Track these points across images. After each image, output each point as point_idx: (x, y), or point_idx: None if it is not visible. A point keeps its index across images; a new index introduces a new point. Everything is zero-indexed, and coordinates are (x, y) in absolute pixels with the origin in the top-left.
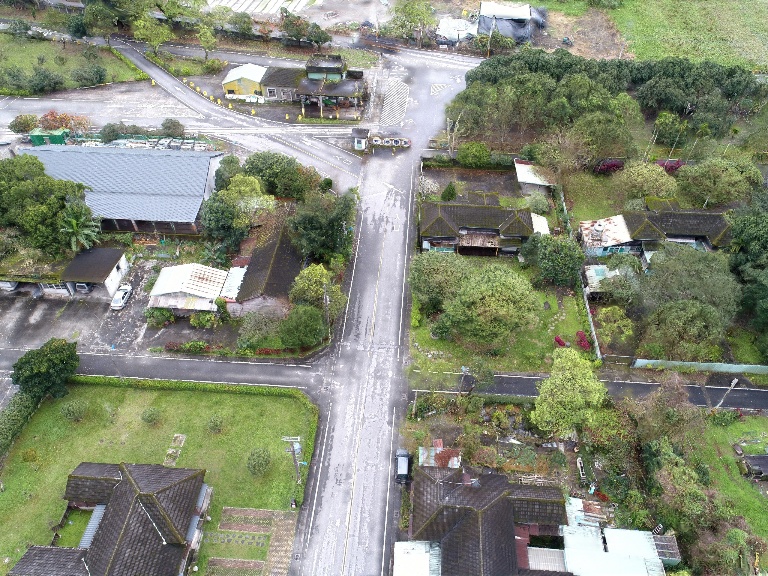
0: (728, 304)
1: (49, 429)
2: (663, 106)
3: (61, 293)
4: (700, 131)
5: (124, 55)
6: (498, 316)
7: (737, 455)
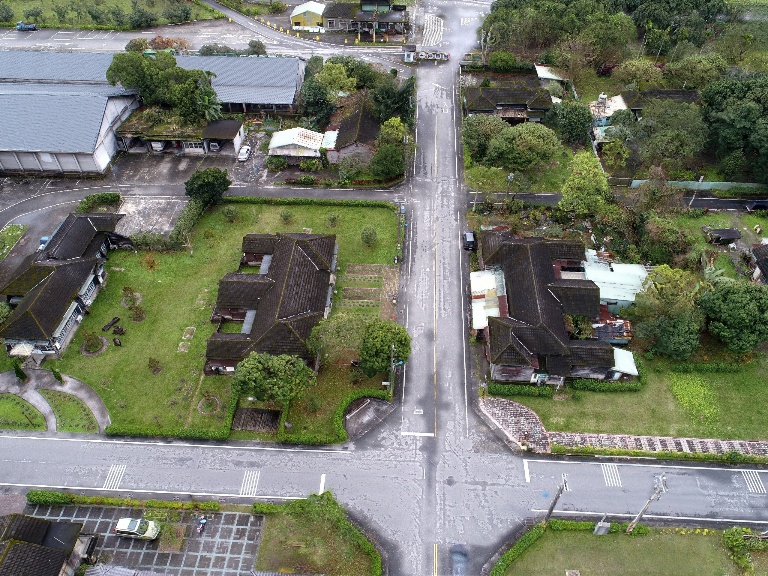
0: (698, 136)
1: (213, 226)
2: (652, 26)
3: (198, 152)
4: (680, 35)
5: (200, 1)
6: (532, 147)
7: (704, 233)
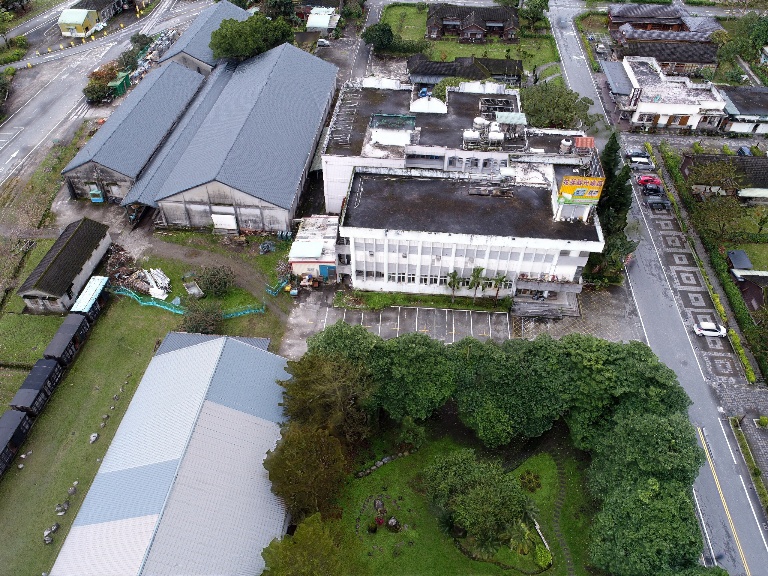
0: None
1: None
2: None
3: None
4: None
5: None
6: None
7: None
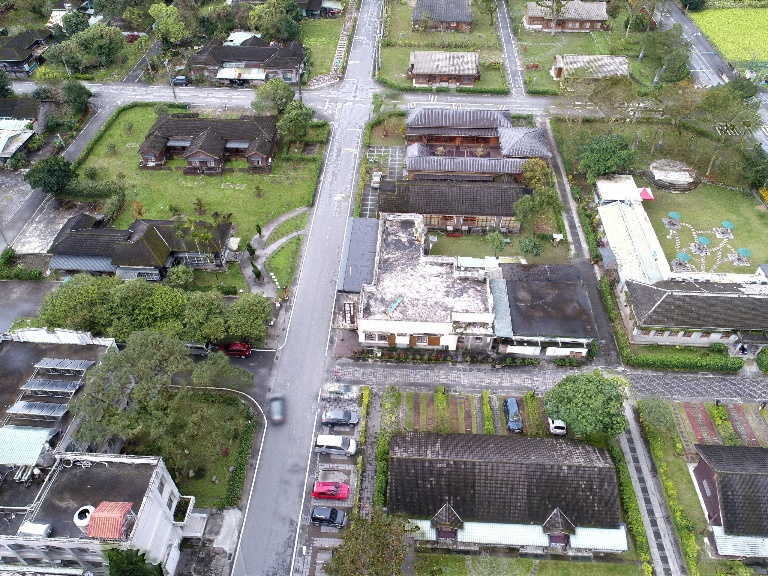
0: None
1: None
2: None
3: None
4: None
5: None
6: (114, 33)
7: None
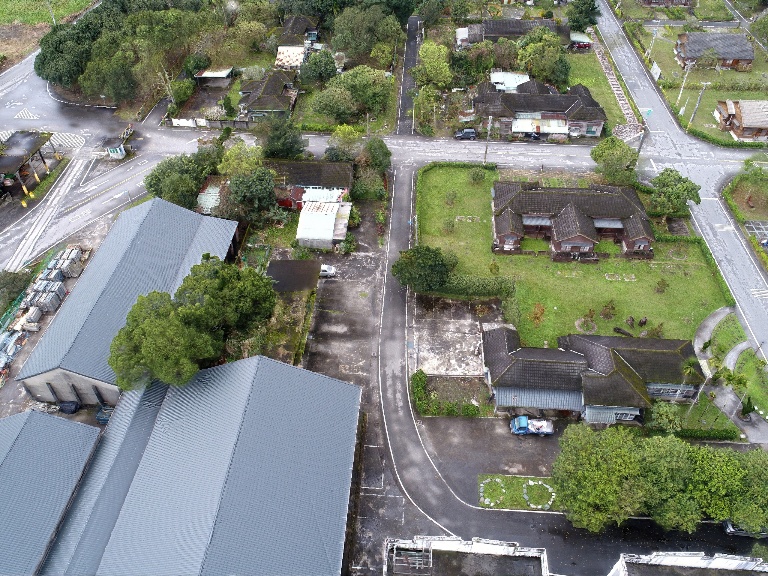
0: None
1: None
2: None
3: None
4: None
5: None
6: None
7: None
